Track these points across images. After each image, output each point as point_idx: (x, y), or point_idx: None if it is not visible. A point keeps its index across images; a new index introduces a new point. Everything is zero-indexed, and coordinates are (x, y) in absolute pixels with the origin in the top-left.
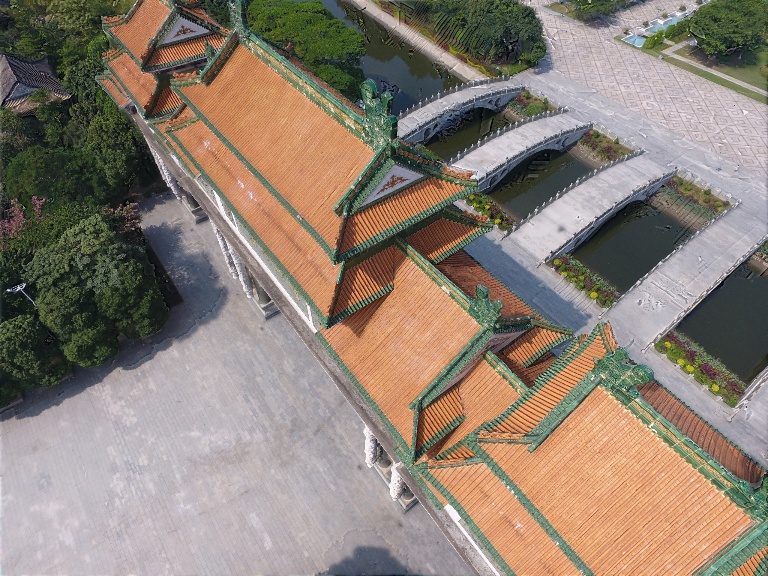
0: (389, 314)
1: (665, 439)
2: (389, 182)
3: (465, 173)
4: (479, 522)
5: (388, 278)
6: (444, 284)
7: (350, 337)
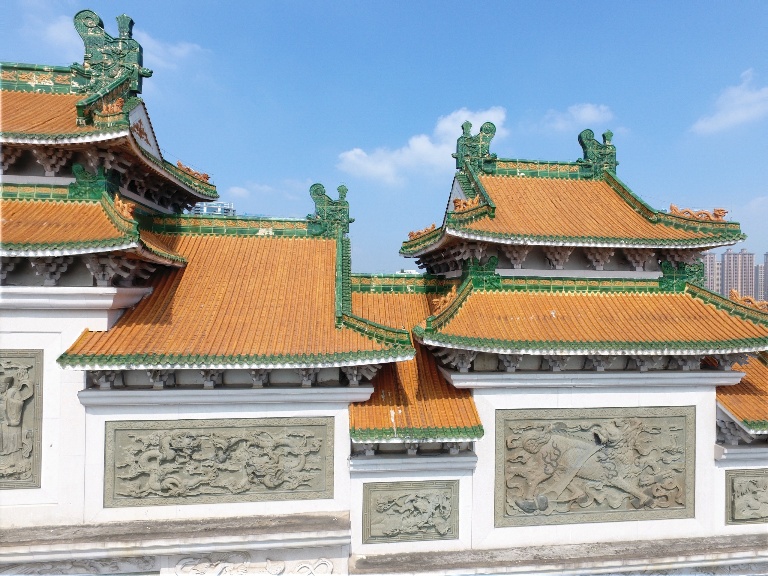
0: (203, 284)
1: (531, 174)
2: (137, 126)
3: (201, 174)
4: None
5: (171, 253)
6: (260, 225)
7: (151, 331)
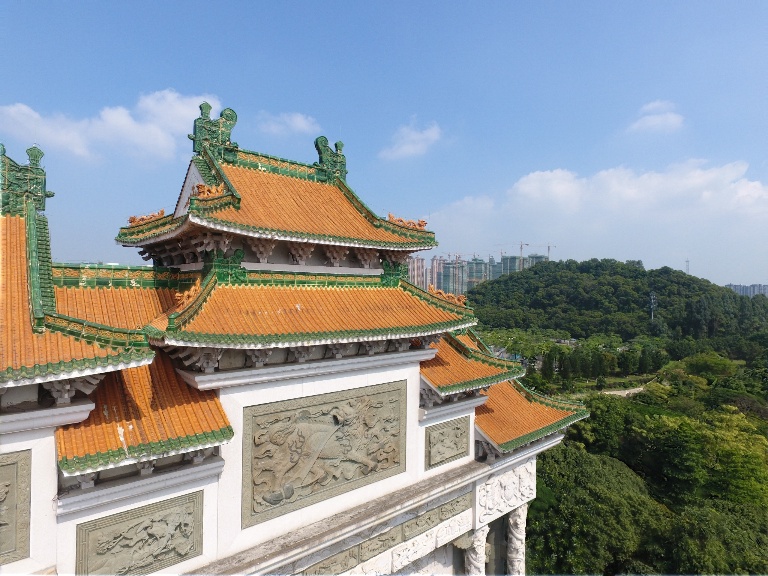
0: None
1: (273, 170)
2: None
3: None
4: (282, 331)
5: None
6: None
7: None
